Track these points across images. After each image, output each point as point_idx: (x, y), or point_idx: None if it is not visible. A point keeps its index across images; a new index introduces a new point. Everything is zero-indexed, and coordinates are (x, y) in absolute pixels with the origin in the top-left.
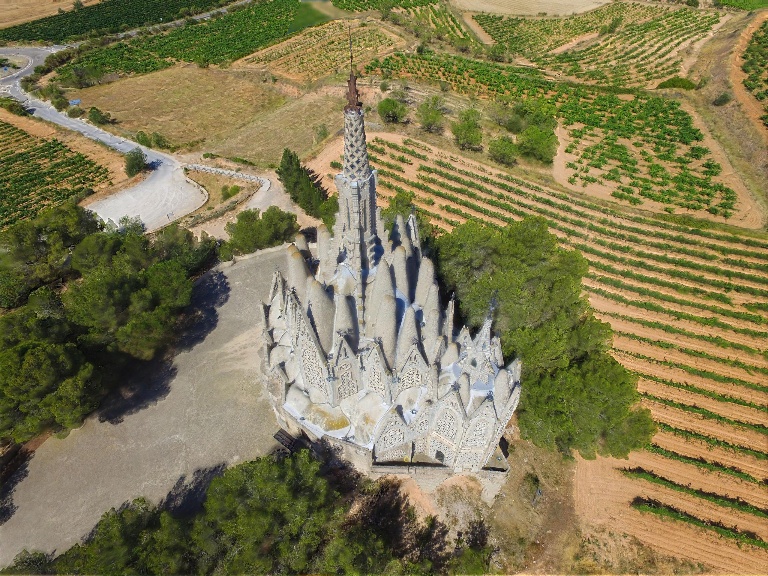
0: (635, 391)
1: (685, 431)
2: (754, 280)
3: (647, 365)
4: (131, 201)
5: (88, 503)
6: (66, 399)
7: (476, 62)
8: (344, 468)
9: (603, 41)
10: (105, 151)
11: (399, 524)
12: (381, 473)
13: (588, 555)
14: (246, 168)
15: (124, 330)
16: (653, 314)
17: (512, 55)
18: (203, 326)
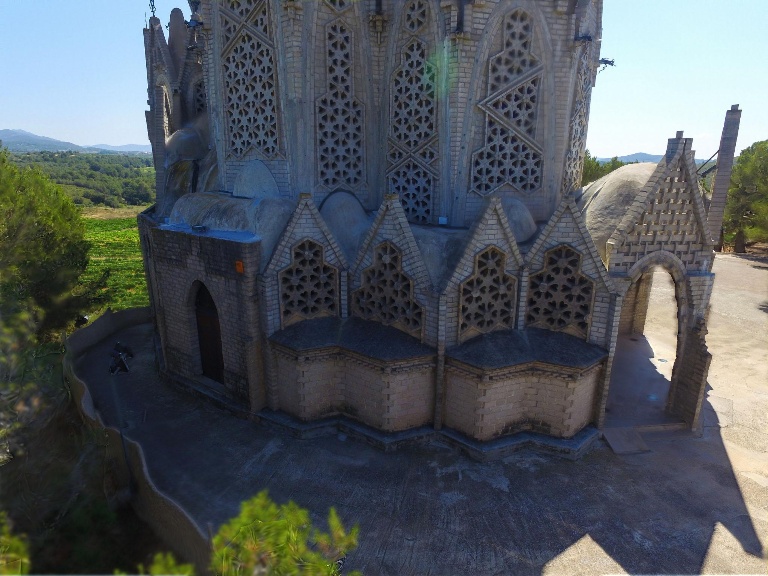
0: None
1: None
2: None
3: None
4: None
5: None
6: None
7: None
8: None
9: None
10: None
11: None
12: None
13: None
14: None
15: None
16: None
17: None
18: None
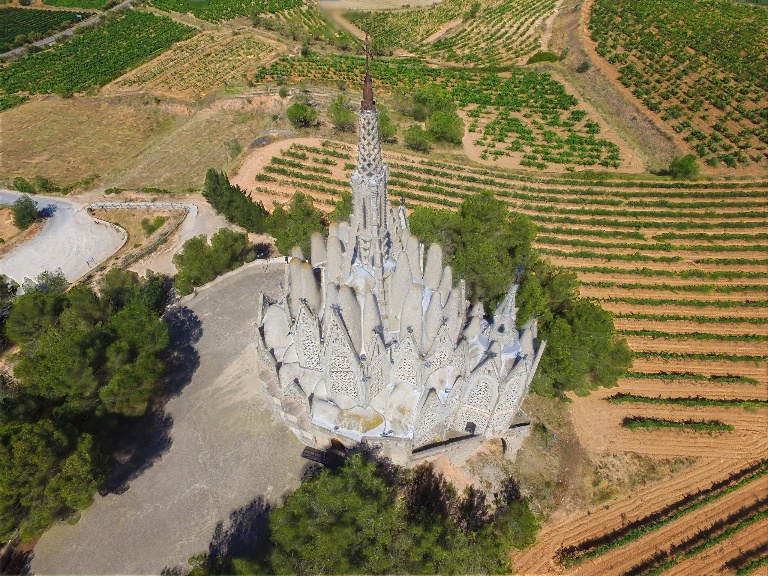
0: None
1: (643, 353)
2: (655, 215)
3: None
4: (34, 255)
5: None
6: (76, 478)
7: (361, 58)
8: (381, 466)
9: (469, 26)
10: None
11: (442, 503)
12: (419, 459)
13: (603, 479)
14: (162, 197)
15: (109, 389)
16: (588, 261)
17: (391, 48)
18: (185, 367)
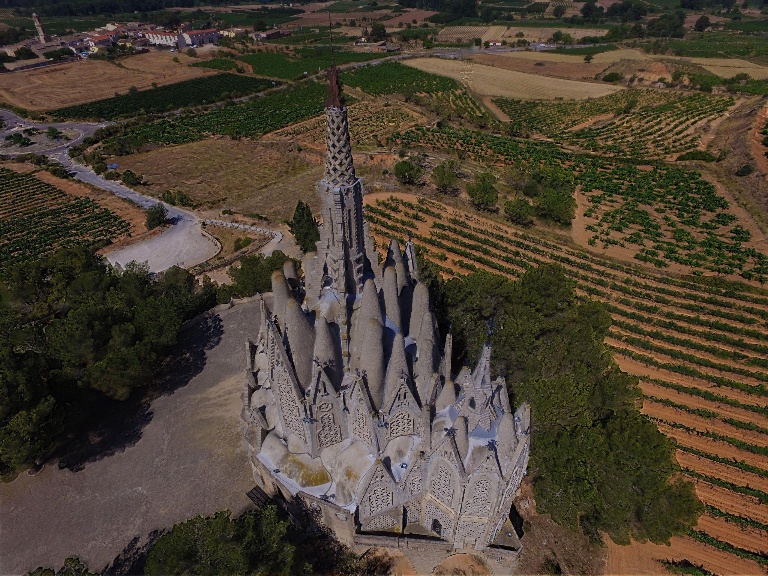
0: (673, 458)
1: (739, 517)
2: None
3: (686, 436)
4: (146, 251)
5: (24, 563)
6: (15, 434)
7: (494, 136)
8: (324, 537)
9: (619, 120)
10: (132, 208)
11: None
12: (366, 545)
13: None
14: (261, 223)
15: (99, 365)
16: (689, 379)
17: (529, 131)
18: (189, 369)
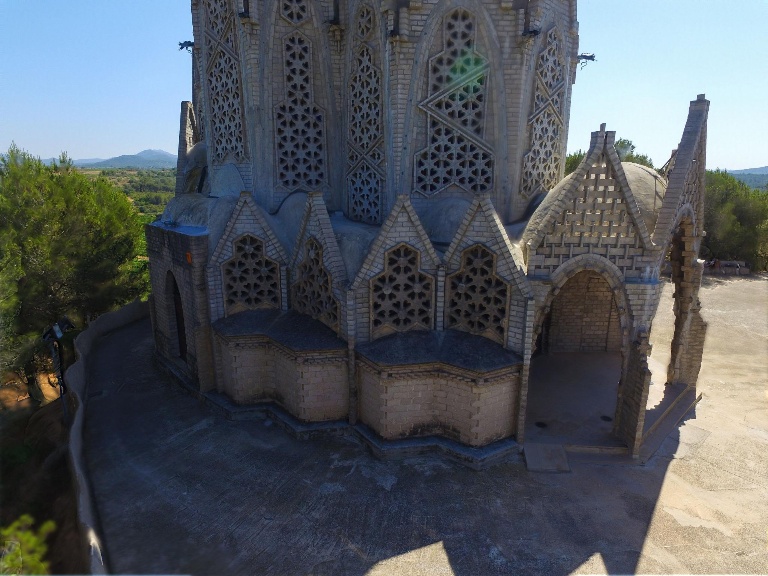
0: None
1: None
2: None
3: None
4: None
5: (767, 292)
6: None
7: None
8: None
9: None
10: None
11: None
12: None
13: None
14: None
15: None
16: None
17: None
18: None
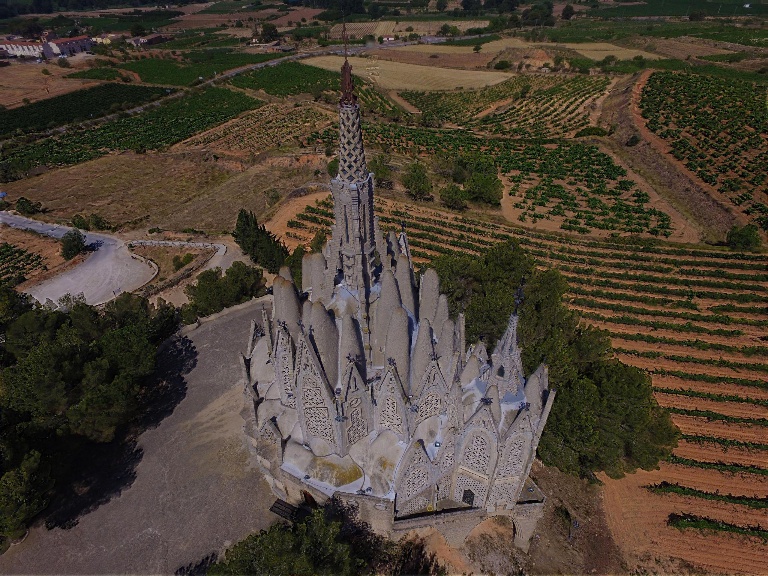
0: None
1: (696, 436)
2: (710, 285)
3: None
4: (70, 284)
5: None
6: (6, 498)
7: (410, 128)
8: (359, 533)
9: (518, 105)
10: (36, 239)
11: None
12: (404, 530)
13: None
14: (198, 237)
15: (77, 408)
16: (631, 328)
17: (441, 121)
18: (170, 397)
